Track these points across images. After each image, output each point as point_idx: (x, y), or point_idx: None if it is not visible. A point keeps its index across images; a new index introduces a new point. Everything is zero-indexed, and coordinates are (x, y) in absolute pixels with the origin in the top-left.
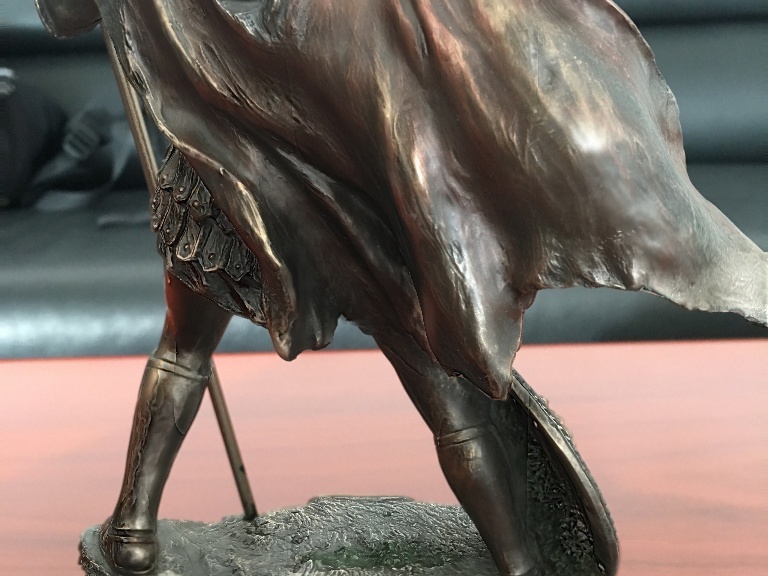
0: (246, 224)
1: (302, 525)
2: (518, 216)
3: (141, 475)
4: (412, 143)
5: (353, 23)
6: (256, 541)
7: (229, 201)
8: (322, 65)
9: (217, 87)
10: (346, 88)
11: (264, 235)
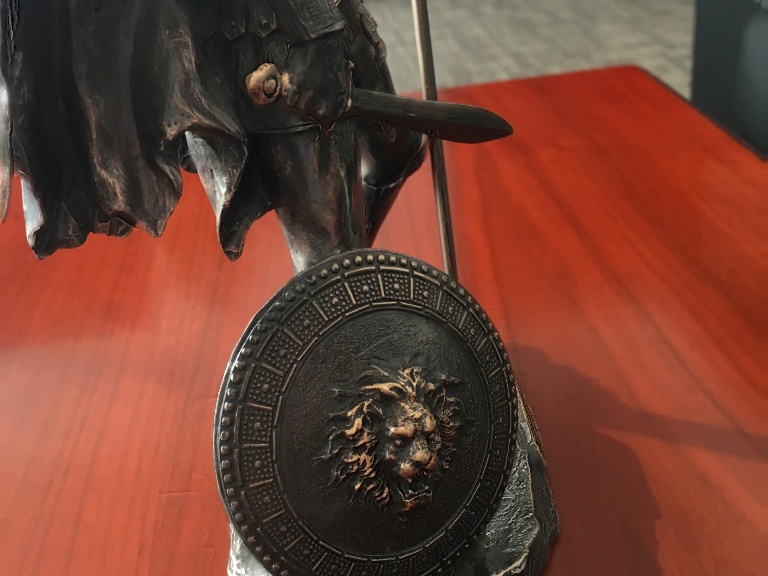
0: None
1: None
2: None
3: None
4: (10, 1)
5: None
6: None
7: None
8: None
9: None
10: None
11: None
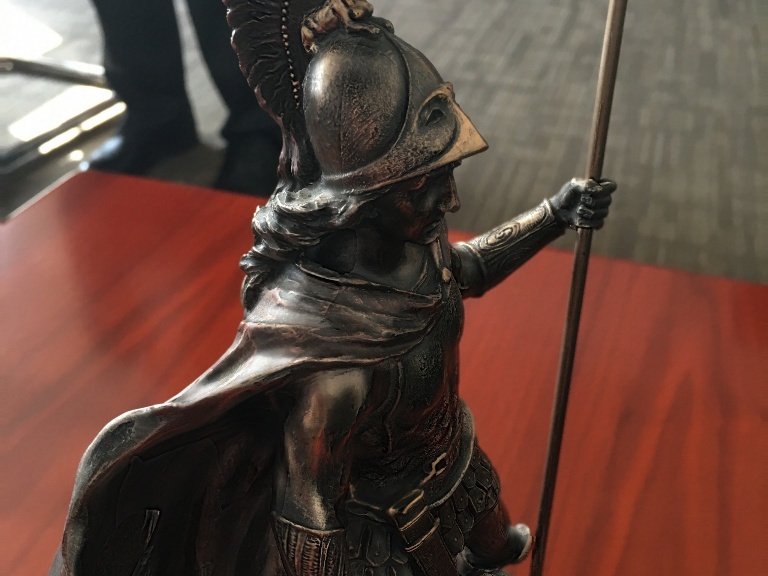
0: None
1: None
2: (119, 571)
3: None
4: None
5: None
6: None
7: None
8: None
9: None
10: None
11: None
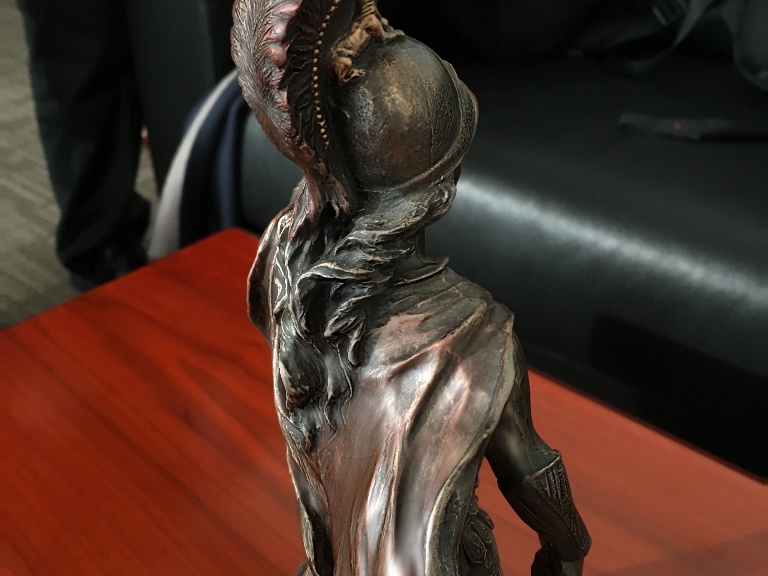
0: (303, 543)
1: None
2: None
3: (311, 575)
4: None
5: (343, 496)
6: None
7: (299, 519)
8: (329, 502)
9: (293, 453)
10: (332, 534)
11: (312, 556)
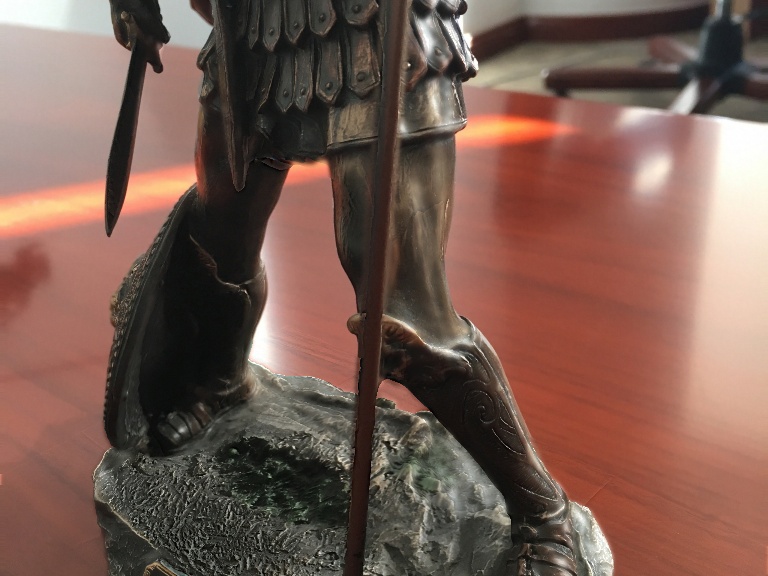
0: None
1: (307, 574)
2: None
3: None
4: None
5: None
6: (375, 574)
7: None
8: None
9: None
10: None
11: None
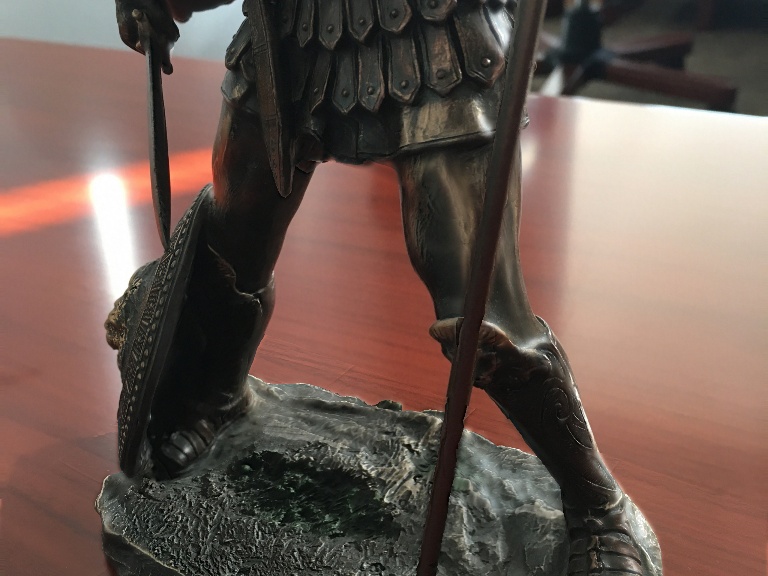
0: None
1: None
2: None
3: None
4: None
5: None
6: None
7: None
8: None
9: None
10: None
11: None
